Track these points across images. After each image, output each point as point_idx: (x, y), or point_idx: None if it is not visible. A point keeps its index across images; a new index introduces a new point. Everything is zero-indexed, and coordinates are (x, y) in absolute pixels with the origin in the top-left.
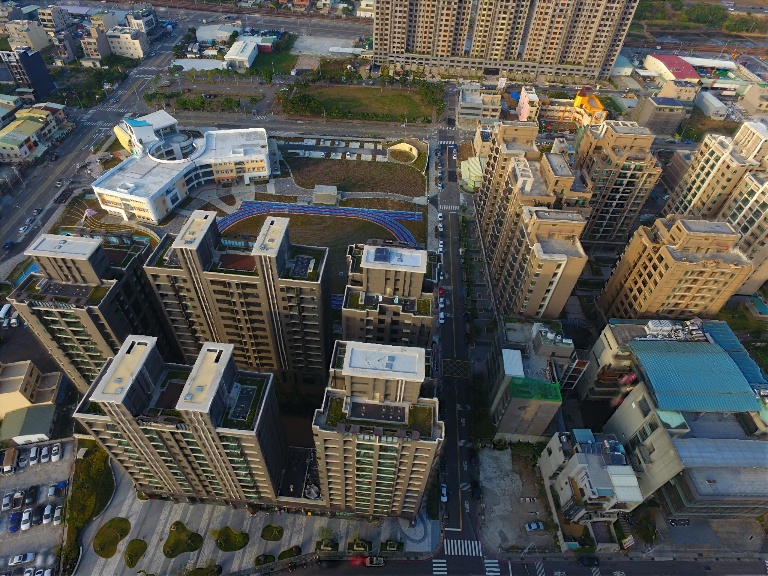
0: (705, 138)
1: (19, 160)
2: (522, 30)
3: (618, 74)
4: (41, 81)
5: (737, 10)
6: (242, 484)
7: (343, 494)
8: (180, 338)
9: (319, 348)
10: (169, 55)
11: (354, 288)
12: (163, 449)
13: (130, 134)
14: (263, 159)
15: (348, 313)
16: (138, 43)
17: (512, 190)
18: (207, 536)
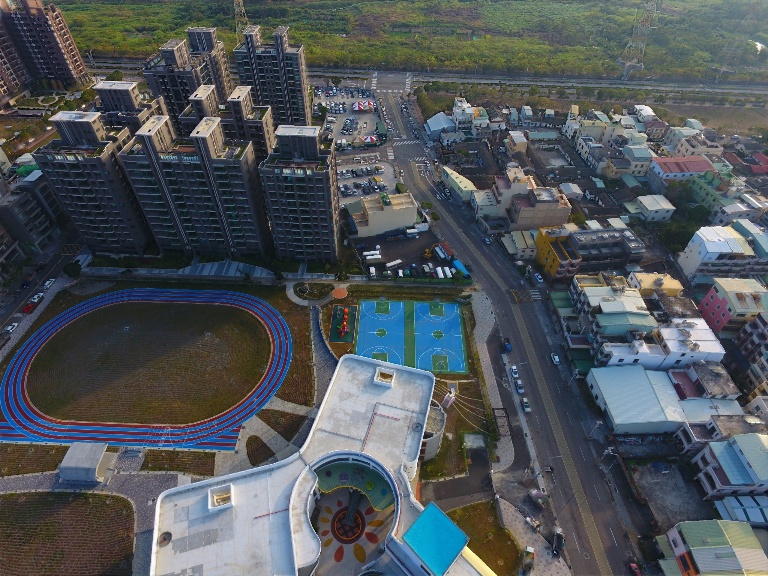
0: None
1: None
2: None
3: None
4: None
5: None
6: None
7: None
8: None
9: None
10: None
11: None
12: None
13: None
14: None
15: None
16: None
17: None
18: None
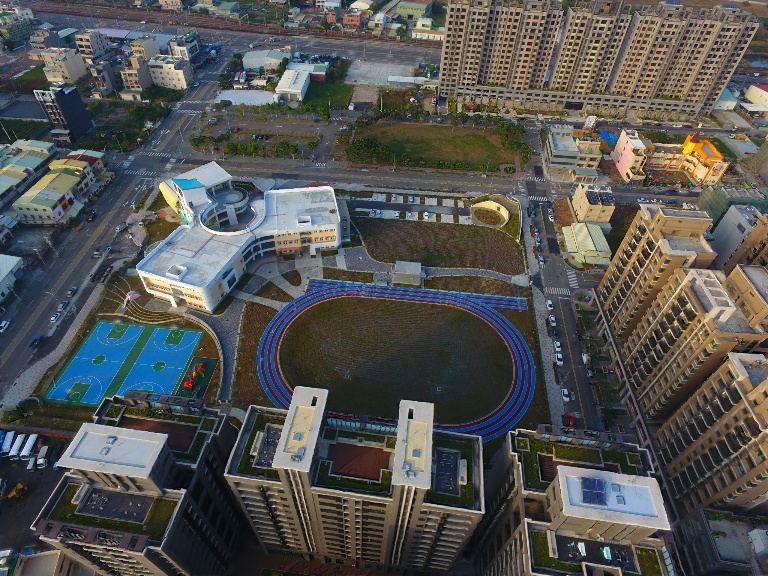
0: None
1: (52, 222)
2: (614, 60)
3: (719, 108)
4: (78, 121)
5: None
6: None
7: None
8: (259, 529)
9: (451, 557)
10: (214, 85)
11: (536, 524)
12: None
13: (179, 195)
14: (334, 228)
15: None
16: (182, 73)
17: (695, 316)
18: None
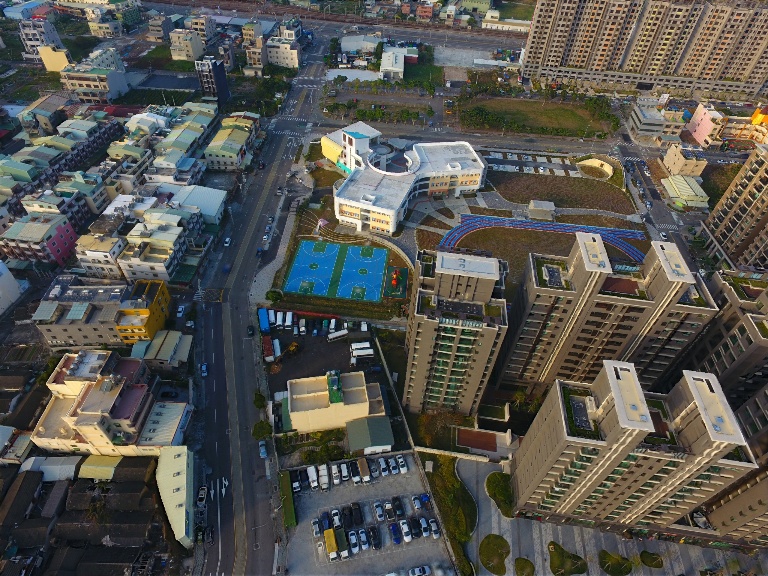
0: None
1: (233, 168)
2: (684, 45)
3: None
4: (222, 90)
5: None
6: (656, 511)
7: (759, 526)
8: (512, 356)
9: (659, 372)
10: (320, 65)
11: (755, 317)
12: (616, 474)
13: (345, 145)
14: (479, 173)
15: (765, 343)
16: (296, 53)
17: None
18: (588, 559)
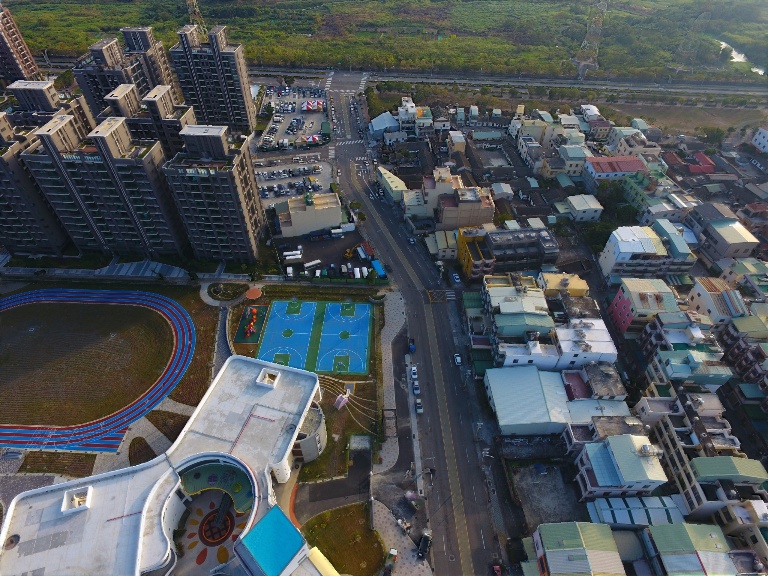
0: None
1: None
2: None
3: None
4: None
5: None
6: None
7: None
8: None
9: None
10: None
11: None
12: None
13: None
14: None
15: None
16: None
17: None
18: None
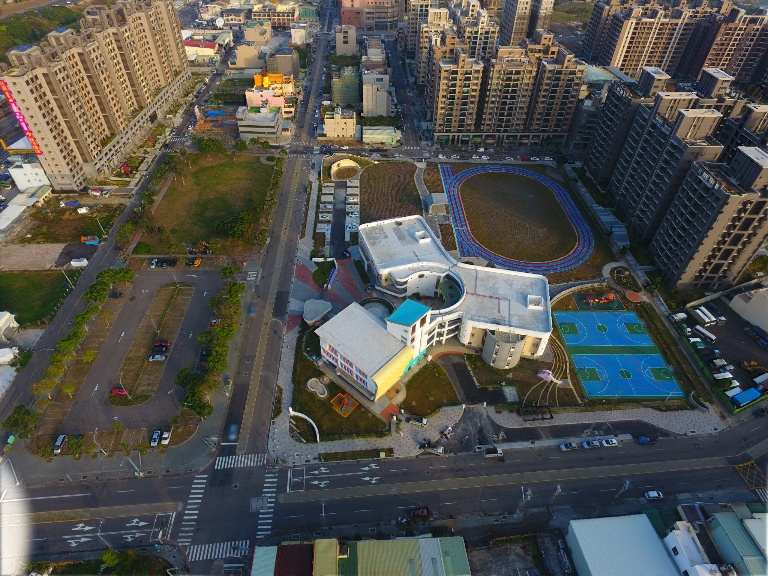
0: (423, 29)
1: None
2: None
3: None
4: None
5: (61, 5)
6: None
7: None
8: None
9: None
10: None
11: None
12: None
13: None
14: None
15: None
16: None
17: (520, 71)
18: None
